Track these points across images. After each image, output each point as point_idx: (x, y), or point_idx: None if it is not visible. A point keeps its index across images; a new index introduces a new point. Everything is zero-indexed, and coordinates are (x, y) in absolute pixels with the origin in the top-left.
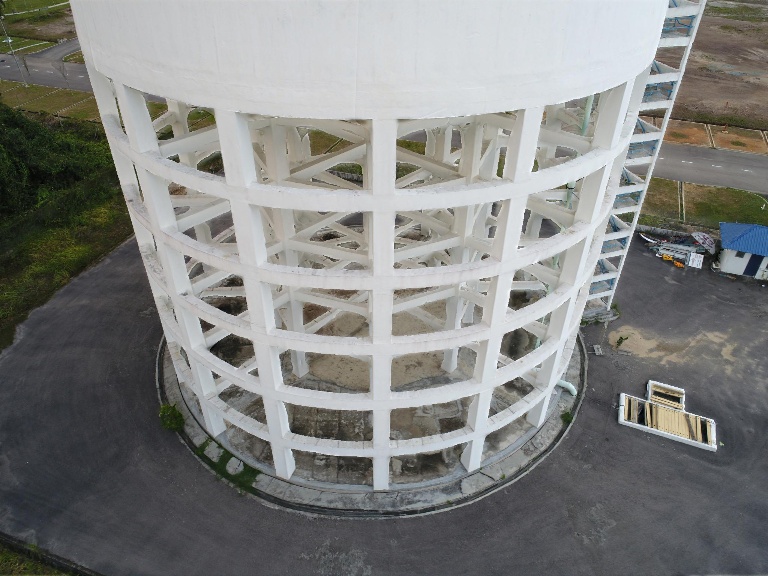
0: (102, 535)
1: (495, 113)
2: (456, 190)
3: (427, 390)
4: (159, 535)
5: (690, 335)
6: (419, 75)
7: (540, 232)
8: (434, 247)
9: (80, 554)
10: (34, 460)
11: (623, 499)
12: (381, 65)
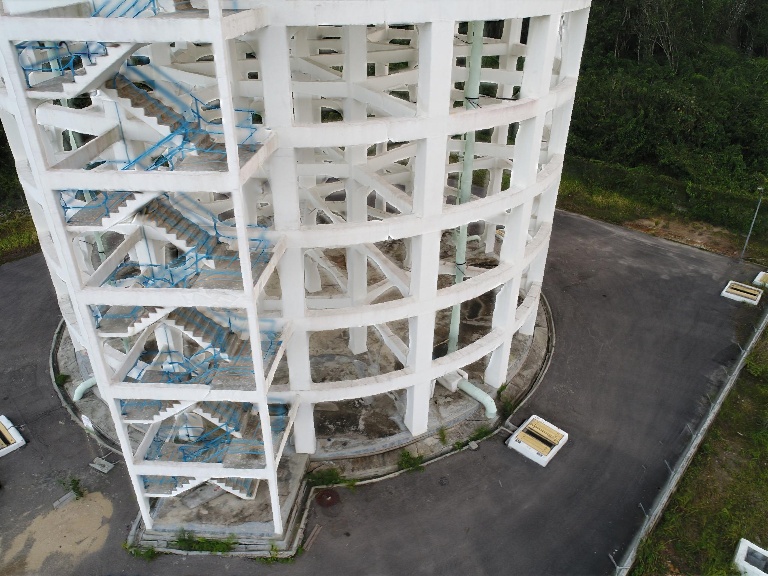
0: None
1: None
2: None
3: None
4: None
5: None
6: None
7: None
8: None
9: None
10: None
11: None
12: None
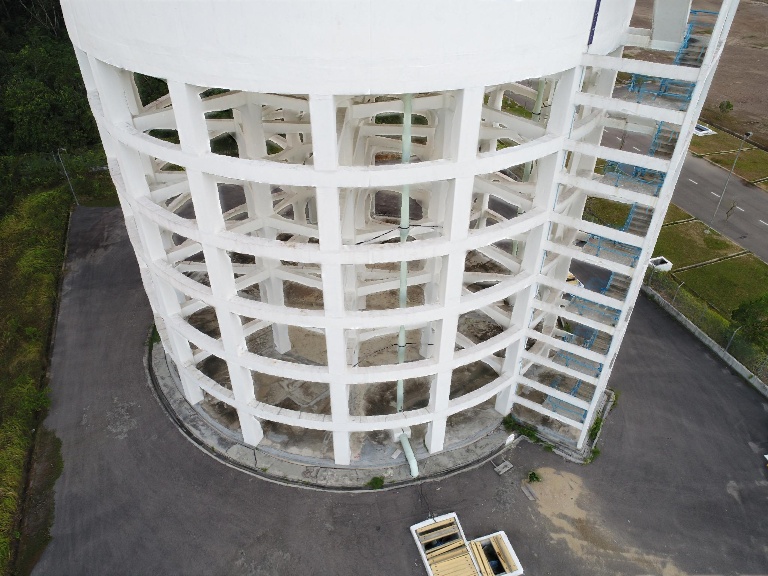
0: (82, 312)
1: (337, 113)
2: (145, 138)
3: (193, 328)
4: (94, 331)
5: (642, 547)
6: (93, 23)
7: (648, 342)
8: (315, 233)
9: (65, 313)
10: (116, 258)
11: (311, 573)
12: (77, 8)
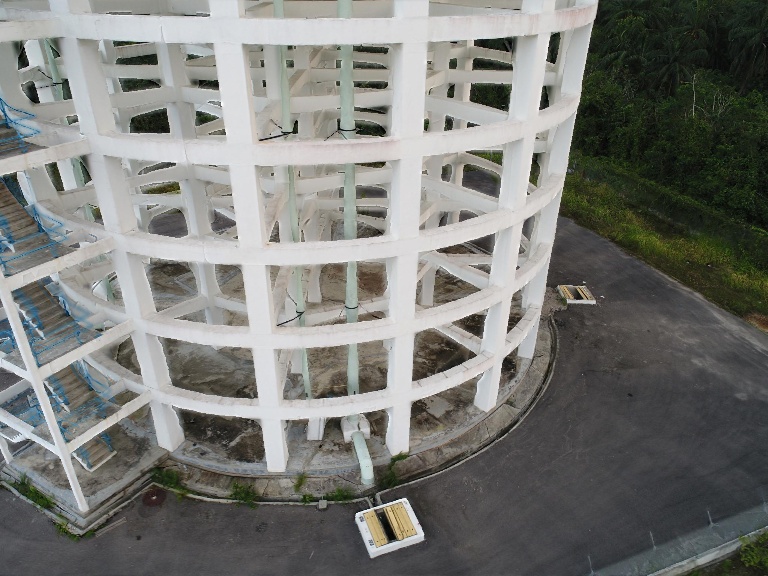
0: None
1: None
2: None
3: None
4: None
5: None
6: None
7: None
8: None
9: None
10: None
11: None
12: None
